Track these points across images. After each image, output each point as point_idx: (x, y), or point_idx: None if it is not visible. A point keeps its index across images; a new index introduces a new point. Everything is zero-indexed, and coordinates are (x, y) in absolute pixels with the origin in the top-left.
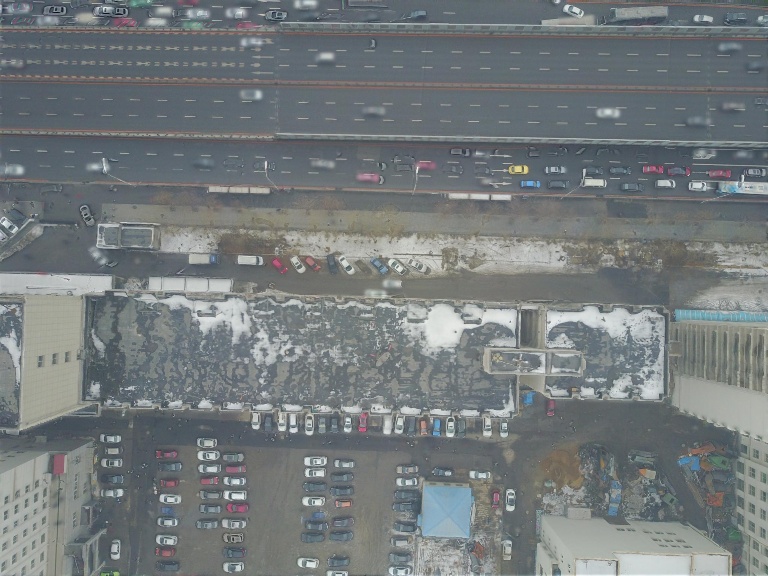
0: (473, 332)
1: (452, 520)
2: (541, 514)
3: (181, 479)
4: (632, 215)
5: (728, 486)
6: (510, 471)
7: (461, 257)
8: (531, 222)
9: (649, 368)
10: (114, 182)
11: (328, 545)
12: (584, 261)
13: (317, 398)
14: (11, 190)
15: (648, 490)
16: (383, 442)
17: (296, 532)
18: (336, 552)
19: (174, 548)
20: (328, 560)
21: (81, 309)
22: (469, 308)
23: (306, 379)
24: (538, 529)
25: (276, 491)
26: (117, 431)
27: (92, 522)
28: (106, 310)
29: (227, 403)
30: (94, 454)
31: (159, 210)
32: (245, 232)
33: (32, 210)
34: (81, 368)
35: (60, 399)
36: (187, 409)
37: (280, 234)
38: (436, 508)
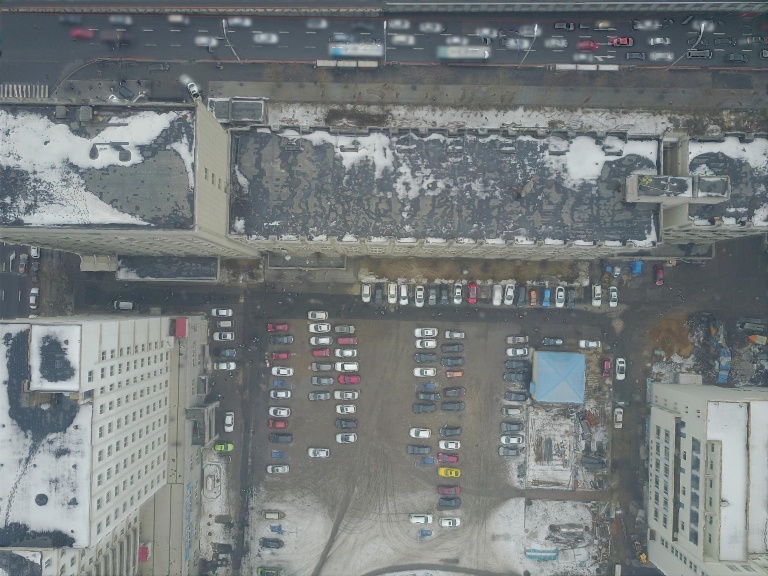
0: (614, 164)
1: (568, 383)
2: (651, 382)
3: (292, 352)
4: (737, 86)
5: None
6: (619, 341)
7: None
8: (636, 94)
9: None
10: (220, 60)
11: (439, 416)
12: (690, 132)
13: (460, 231)
14: (118, 69)
15: (758, 357)
16: (492, 314)
17: (407, 403)
18: (448, 422)
19: (287, 420)
20: (440, 430)
21: (227, 143)
22: (610, 140)
23: (449, 212)
24: (649, 397)
25: (387, 363)
26: (228, 306)
27: (205, 395)
28: (249, 146)
29: (371, 237)
30: (207, 327)
31: (266, 87)
32: (352, 107)
33: (139, 88)
34: (228, 201)
35: (216, 222)
36: (297, 283)
37: (387, 109)
38: (551, 373)
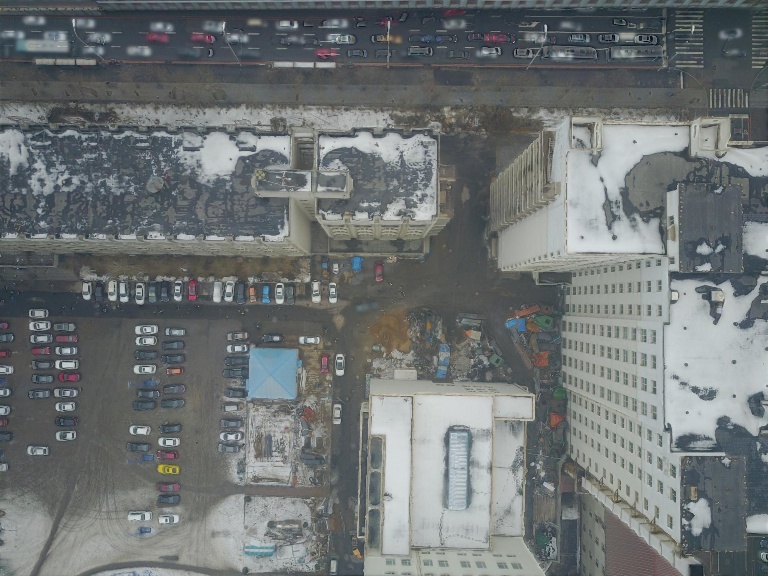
0: (248, 159)
1: (275, 379)
2: (370, 378)
3: (14, 350)
4: (459, 83)
5: (552, 345)
6: (340, 337)
7: None
8: (359, 91)
9: (422, 192)
10: None
11: (160, 413)
12: None
13: (95, 227)
14: None
15: (476, 352)
16: (214, 310)
17: (128, 401)
18: (168, 420)
19: (7, 418)
20: (159, 427)
21: None
22: (244, 135)
23: (84, 208)
24: (367, 393)
25: (108, 361)
26: None
27: None
28: None
29: (6, 233)
30: None
31: None
32: (75, 106)
33: None
34: None
35: None
36: (19, 281)
37: (110, 107)
38: (260, 369)
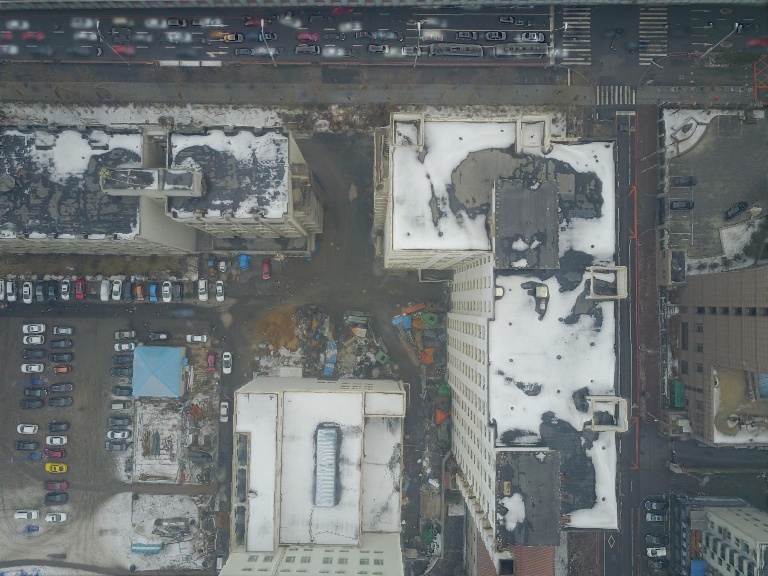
0: (100, 158)
1: (157, 378)
2: (257, 376)
3: None
4: (346, 81)
5: (437, 342)
6: (228, 335)
7: (177, 125)
8: (247, 90)
9: (274, 189)
10: None
11: (48, 411)
12: (299, 127)
13: None
14: None
15: (362, 349)
16: (102, 309)
17: (16, 399)
18: (56, 418)
19: None
20: (47, 426)
21: None
22: (96, 134)
23: None
24: None
25: None
26: None
27: None
28: None
29: None
30: None
31: None
32: None
33: None
34: None
35: None
36: None
37: None
38: (143, 367)
